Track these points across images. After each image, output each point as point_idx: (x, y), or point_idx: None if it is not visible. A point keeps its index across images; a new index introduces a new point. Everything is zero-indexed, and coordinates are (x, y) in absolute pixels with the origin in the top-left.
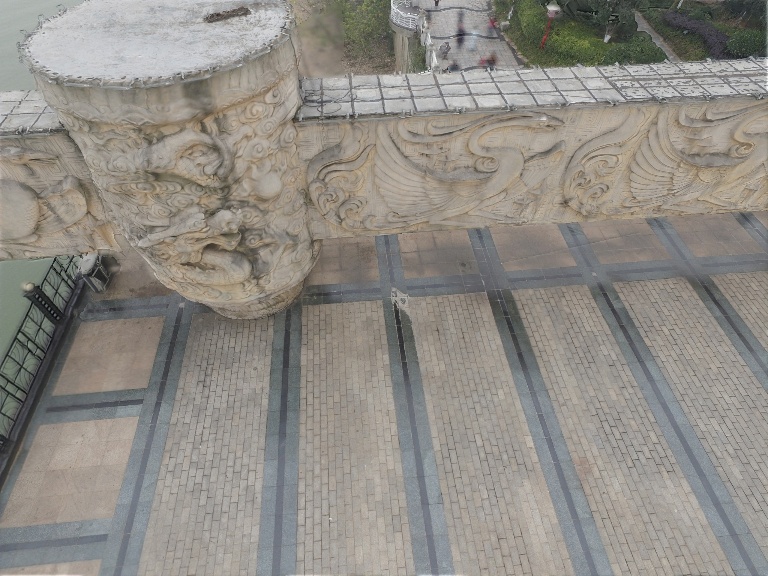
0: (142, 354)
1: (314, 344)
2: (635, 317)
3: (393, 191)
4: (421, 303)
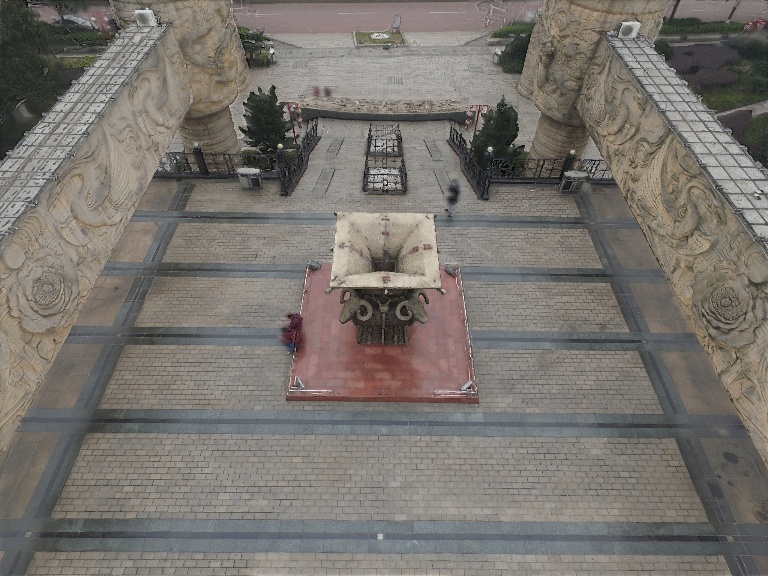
0: None
1: None
2: (101, 514)
3: None
4: None
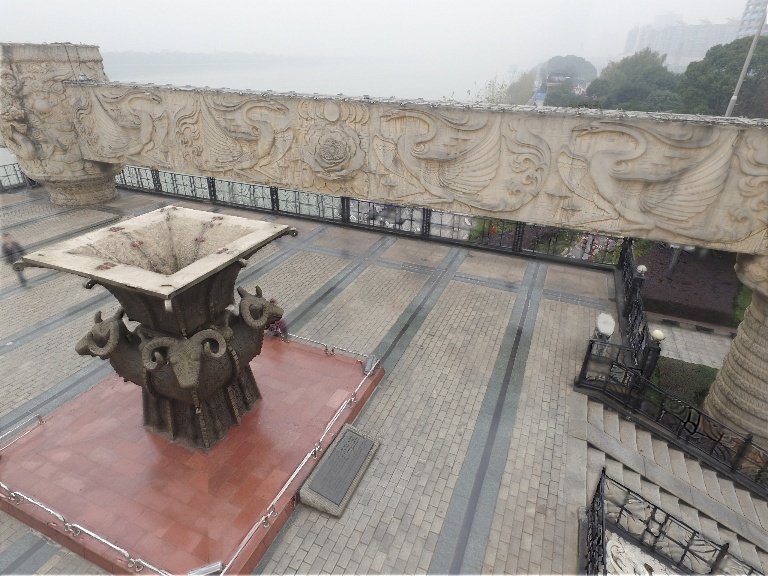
0: (5, 203)
1: (65, 217)
2: None
3: (106, 131)
4: None
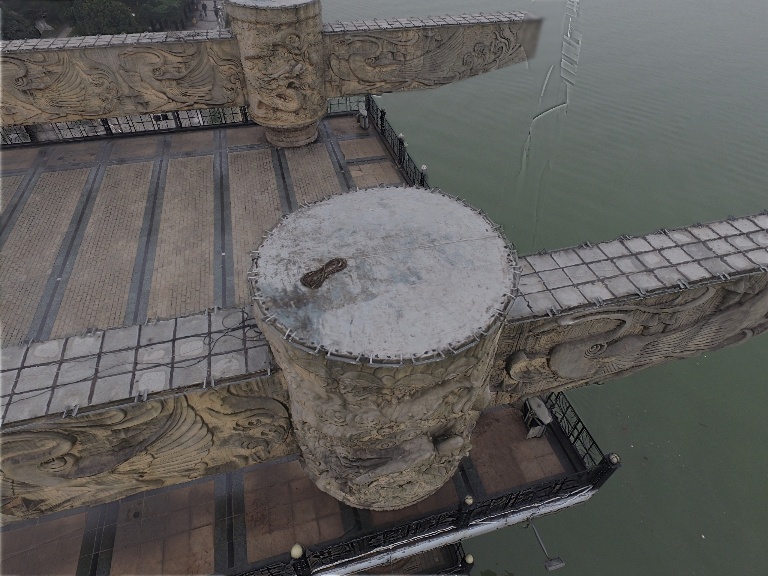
0: None
1: None
2: None
3: None
4: None
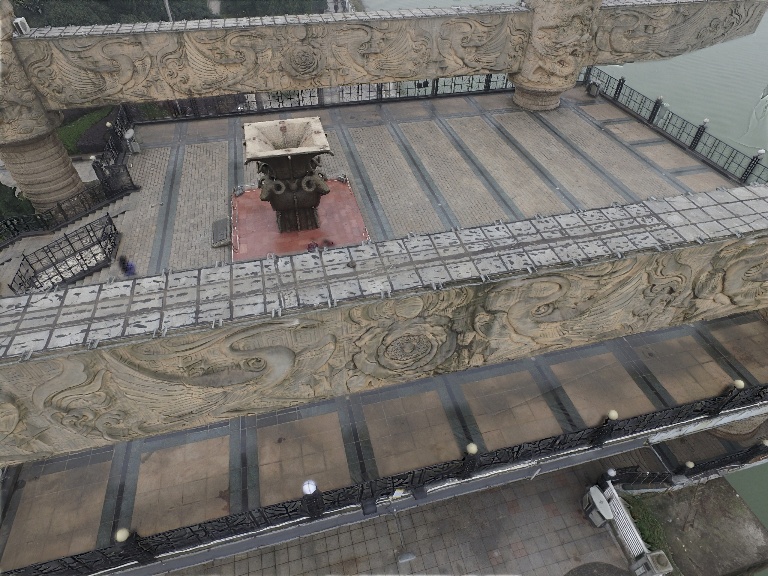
0: None
1: None
2: None
3: None
4: None
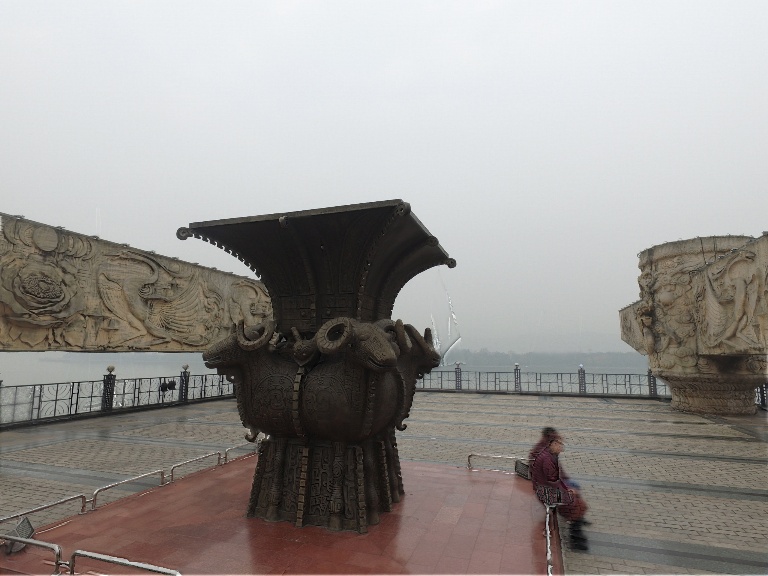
0: None
1: None
2: (767, 465)
3: None
4: (721, 427)
